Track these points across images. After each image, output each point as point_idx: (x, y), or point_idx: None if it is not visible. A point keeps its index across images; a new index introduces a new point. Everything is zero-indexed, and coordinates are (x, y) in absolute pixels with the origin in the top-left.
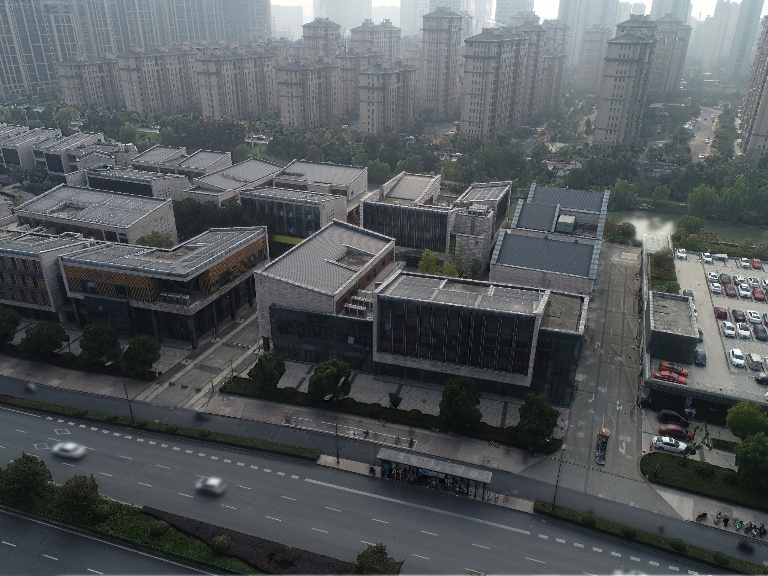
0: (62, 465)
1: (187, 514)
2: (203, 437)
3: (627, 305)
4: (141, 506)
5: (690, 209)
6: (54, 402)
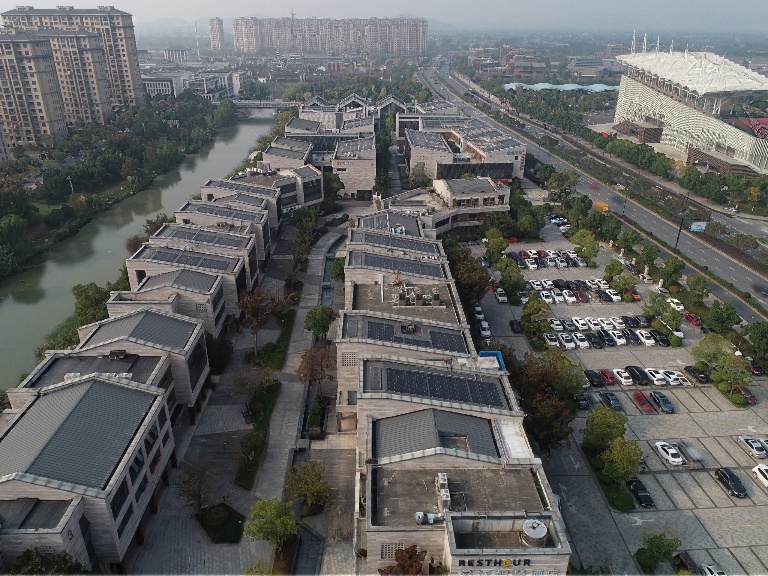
0: None
1: None
2: None
3: None
4: None
5: (222, 122)
6: None
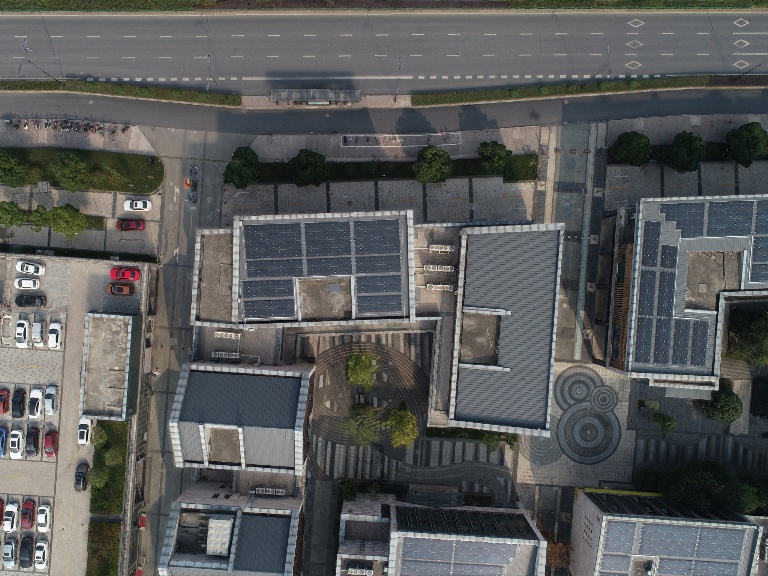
0: (601, 31)
1: (478, 18)
2: (512, 89)
3: (158, 478)
4: (514, 15)
5: None
6: (672, 96)
